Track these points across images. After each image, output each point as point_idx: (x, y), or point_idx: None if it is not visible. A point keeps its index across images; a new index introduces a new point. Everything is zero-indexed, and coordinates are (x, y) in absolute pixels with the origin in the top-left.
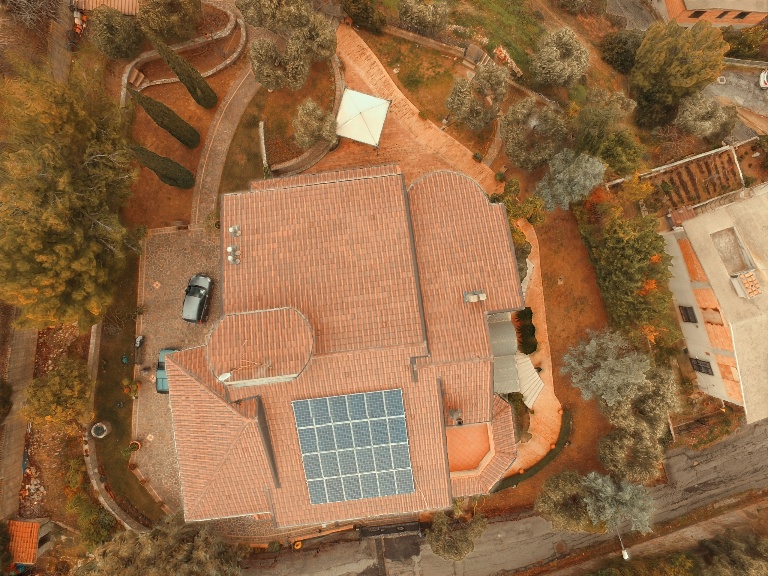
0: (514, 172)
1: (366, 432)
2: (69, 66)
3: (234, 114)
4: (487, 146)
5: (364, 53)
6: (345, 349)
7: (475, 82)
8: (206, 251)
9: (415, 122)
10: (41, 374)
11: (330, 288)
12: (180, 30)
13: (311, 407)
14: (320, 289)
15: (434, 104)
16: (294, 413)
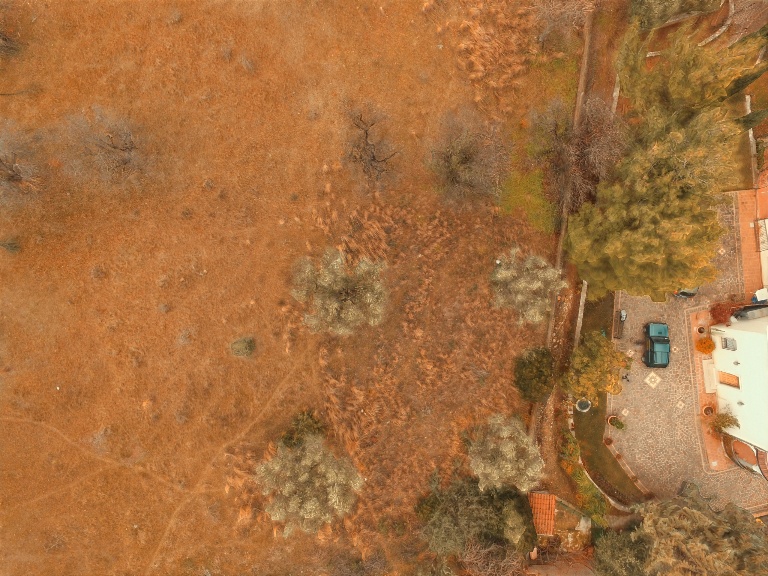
0: None
1: None
2: None
3: None
4: None
5: None
6: None
7: None
8: None
9: None
10: None
11: None
12: None
13: None
14: None
15: None
16: None
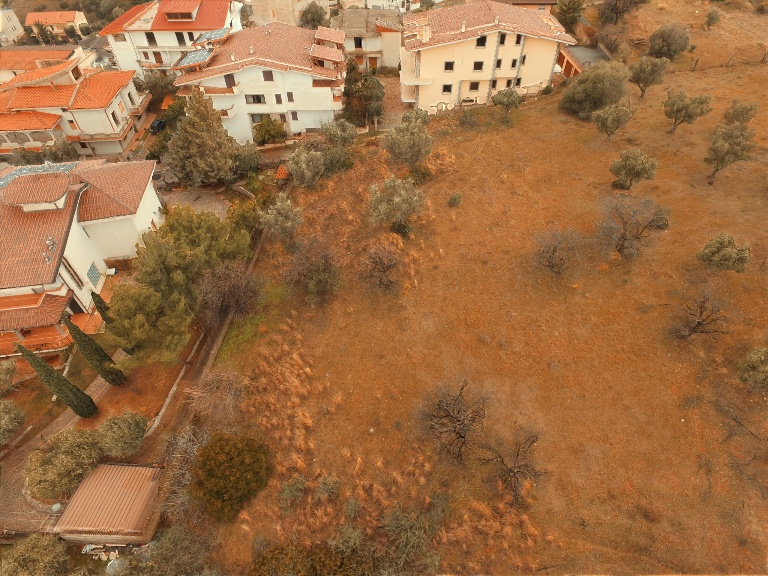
0: None
1: None
2: None
3: None
4: None
5: None
6: None
7: None
8: None
9: None
10: None
11: None
12: None
13: None
14: (2, 228)
15: None
16: None
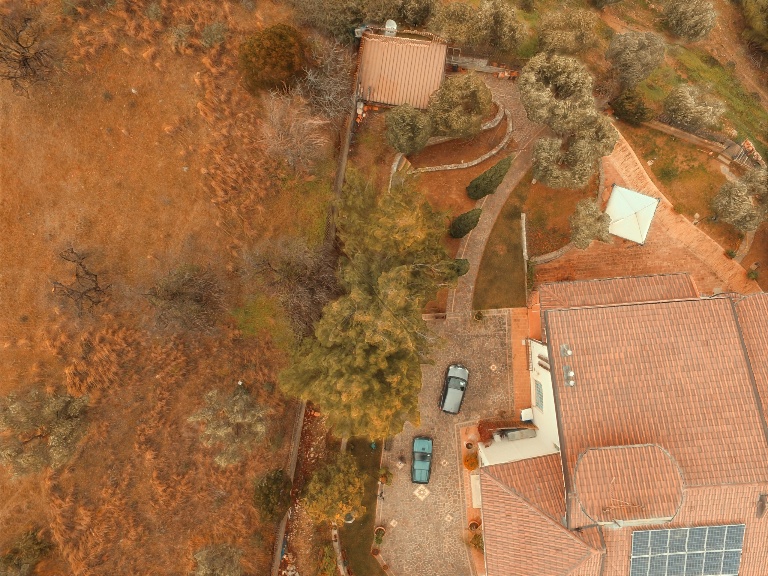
0: (764, 269)
1: (699, 563)
2: (347, 155)
3: (495, 204)
4: (738, 242)
5: (619, 144)
6: (696, 484)
7: (750, 185)
8: (460, 340)
9: (667, 215)
10: (303, 461)
11: (671, 417)
12: (473, 128)
13: (651, 538)
14: (661, 418)
15: (686, 198)
16: (632, 542)
